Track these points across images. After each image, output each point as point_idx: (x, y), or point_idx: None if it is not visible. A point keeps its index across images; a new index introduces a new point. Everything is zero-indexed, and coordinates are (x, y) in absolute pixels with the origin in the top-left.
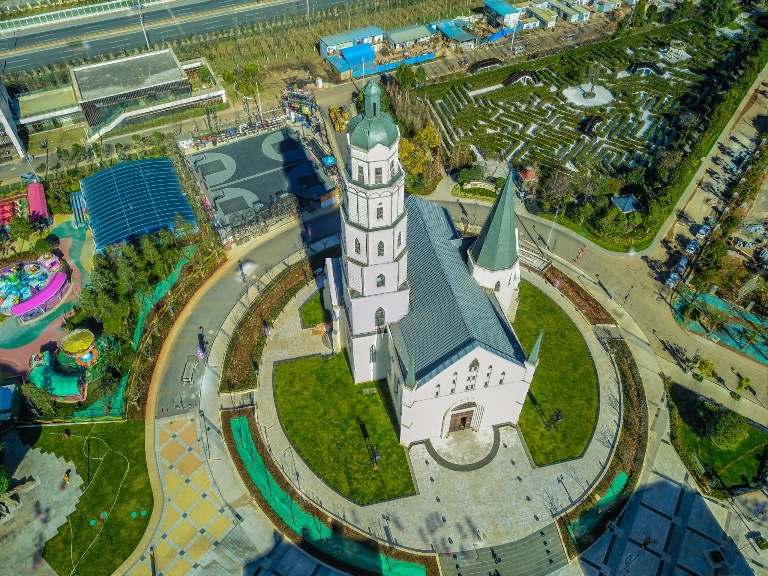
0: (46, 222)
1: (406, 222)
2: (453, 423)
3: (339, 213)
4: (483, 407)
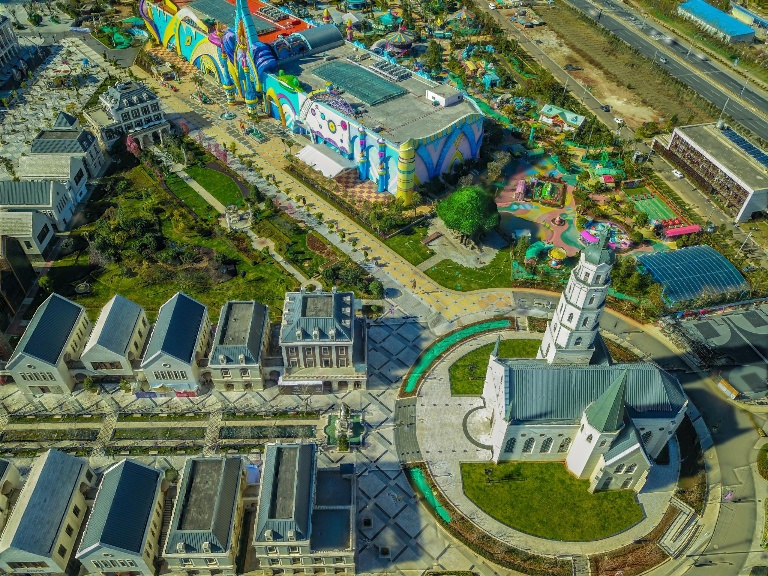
0: (665, 238)
1: (579, 316)
2: None
3: (715, 398)
4: None
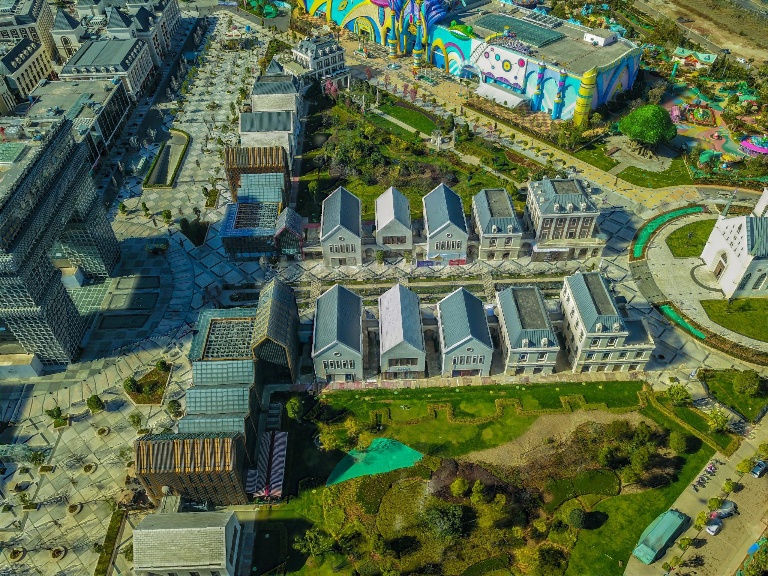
0: None
1: None
2: (717, 269)
3: None
4: (726, 264)
